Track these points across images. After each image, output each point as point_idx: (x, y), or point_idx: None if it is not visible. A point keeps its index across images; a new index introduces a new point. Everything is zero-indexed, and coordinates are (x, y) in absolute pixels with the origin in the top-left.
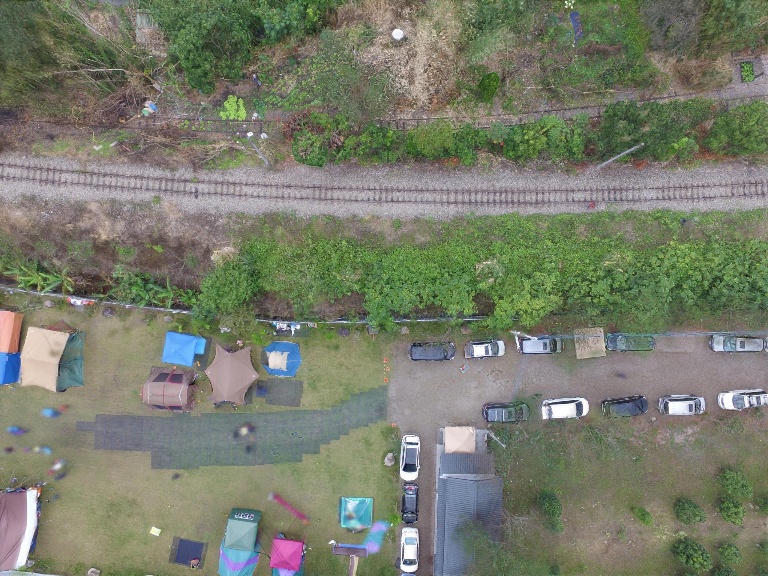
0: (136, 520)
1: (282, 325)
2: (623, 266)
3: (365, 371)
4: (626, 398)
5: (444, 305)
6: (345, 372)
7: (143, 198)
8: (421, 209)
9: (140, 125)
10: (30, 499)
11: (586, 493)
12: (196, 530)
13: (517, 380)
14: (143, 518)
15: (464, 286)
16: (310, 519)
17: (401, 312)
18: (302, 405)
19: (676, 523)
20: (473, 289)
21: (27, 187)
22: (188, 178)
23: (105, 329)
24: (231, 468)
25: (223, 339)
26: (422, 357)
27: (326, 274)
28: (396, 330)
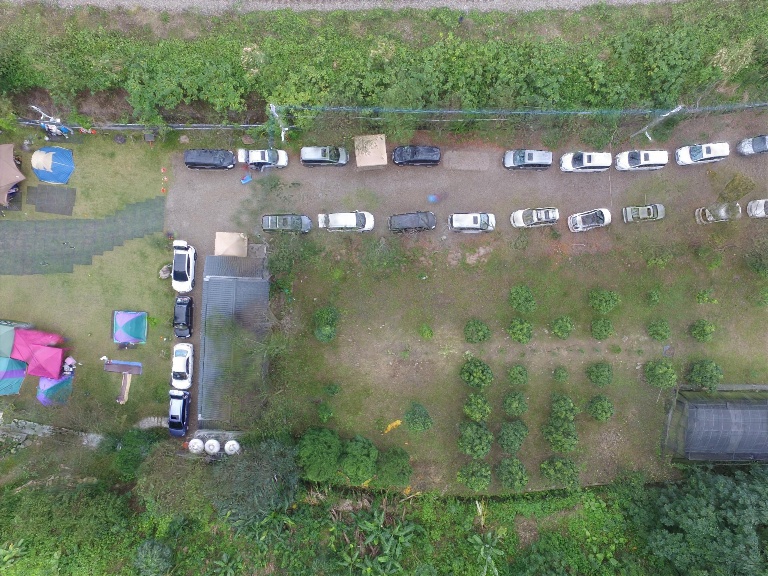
0: None
1: (51, 126)
2: (397, 63)
3: (142, 180)
4: (412, 212)
5: (210, 100)
6: (120, 181)
7: None
8: (189, 2)
9: None
10: None
11: (373, 314)
12: None
13: (302, 194)
14: None
15: (225, 75)
16: (81, 333)
17: (165, 106)
18: (74, 214)
19: (465, 345)
20: (242, 85)
21: None
22: None
23: None
24: None
25: None
26: (194, 160)
27: (86, 64)
28: (175, 139)
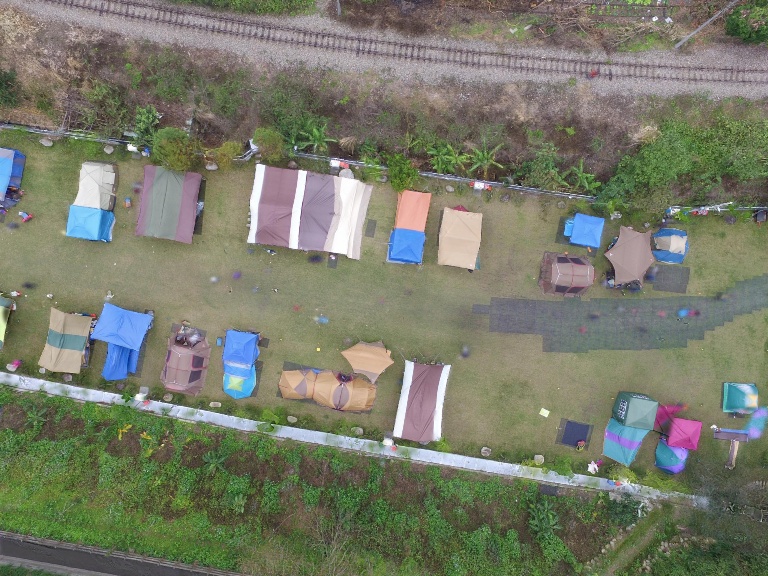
0: (526, 401)
1: (677, 210)
2: None
3: (750, 259)
4: None
5: None
6: (731, 259)
7: (559, 80)
8: None
9: (548, 10)
10: (444, 374)
11: None
12: (583, 412)
13: None
14: (533, 399)
15: None
16: (693, 404)
17: None
18: (688, 291)
19: None
20: None
21: (448, 69)
22: (602, 60)
23: (501, 214)
24: (618, 352)
25: (613, 226)
26: None
27: (740, 155)
28: None
